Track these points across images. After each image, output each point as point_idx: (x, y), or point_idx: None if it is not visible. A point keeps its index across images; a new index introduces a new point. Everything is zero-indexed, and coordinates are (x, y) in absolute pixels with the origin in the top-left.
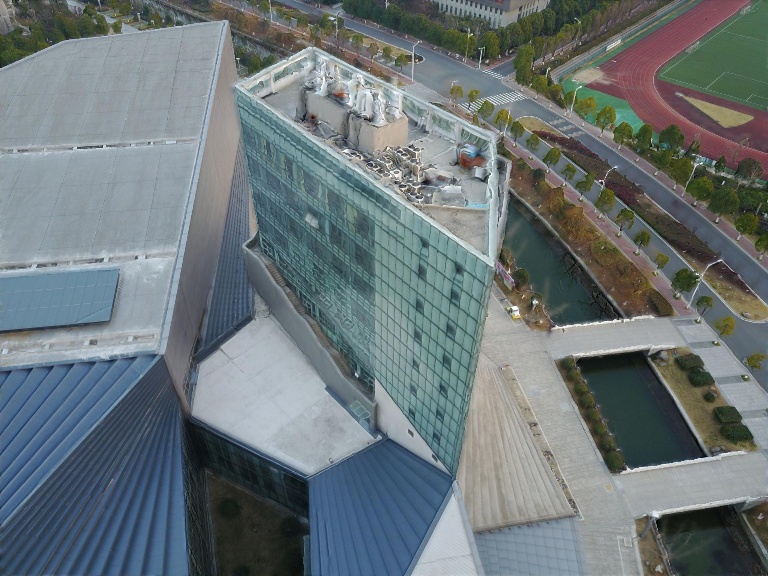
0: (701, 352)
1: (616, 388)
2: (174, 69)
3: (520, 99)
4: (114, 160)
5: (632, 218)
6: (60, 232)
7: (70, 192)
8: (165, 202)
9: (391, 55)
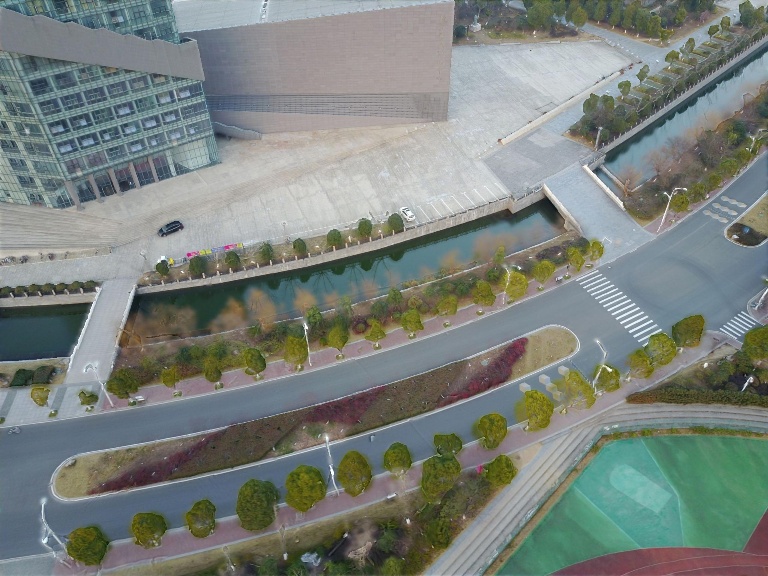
0: (50, 393)
1: (69, 334)
2: (363, 0)
3: (644, 344)
4: (249, 7)
5: (248, 364)
6: (188, 9)
7: (222, 4)
8: (199, 25)
9: (743, 214)
